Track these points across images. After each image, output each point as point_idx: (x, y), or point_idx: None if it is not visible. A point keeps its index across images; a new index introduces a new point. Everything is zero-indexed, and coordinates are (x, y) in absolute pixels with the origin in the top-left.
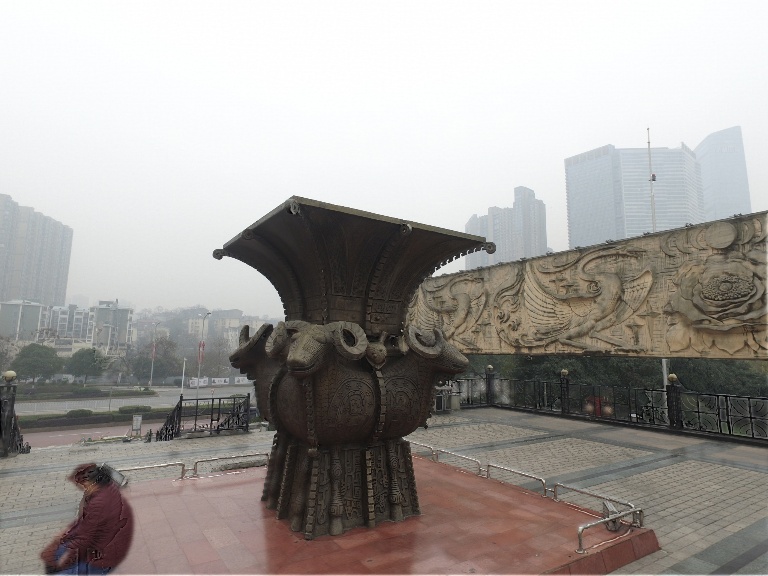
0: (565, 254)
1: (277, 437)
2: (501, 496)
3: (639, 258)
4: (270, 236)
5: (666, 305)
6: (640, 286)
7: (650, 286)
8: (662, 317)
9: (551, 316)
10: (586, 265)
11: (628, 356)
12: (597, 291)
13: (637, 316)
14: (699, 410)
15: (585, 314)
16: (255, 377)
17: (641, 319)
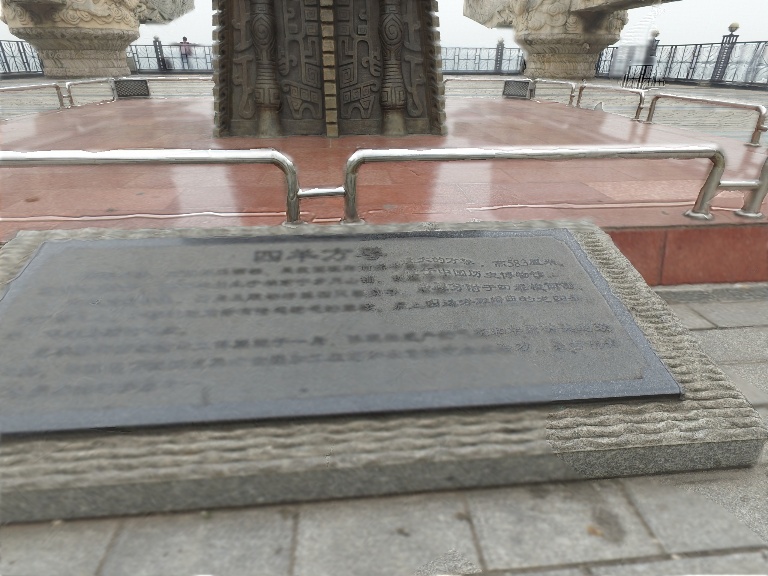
0: None
1: None
2: (104, 112)
3: None
4: None
5: None
6: None
7: None
8: None
9: None
10: None
11: None
12: None
13: None
14: None
15: None
16: None
17: None
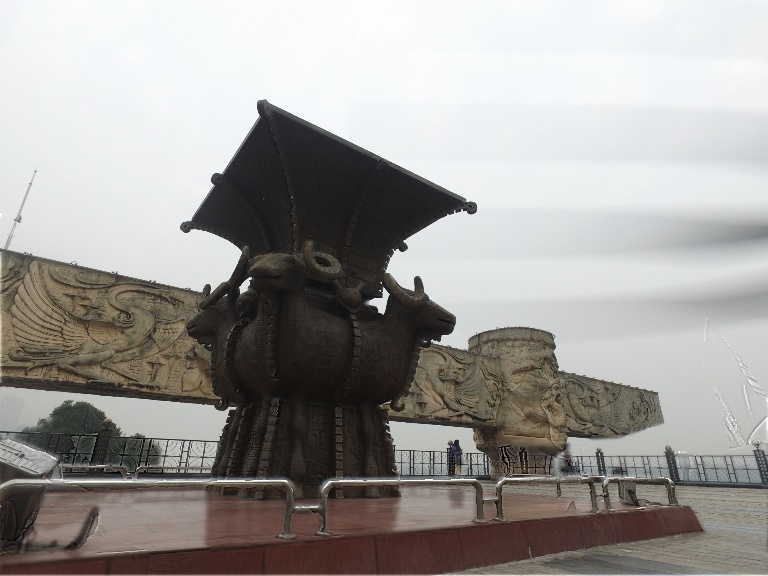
0: (97, 273)
1: (280, 403)
2: None
3: (176, 306)
4: (384, 181)
5: (189, 351)
6: (173, 330)
7: (182, 332)
8: (183, 360)
9: (54, 334)
10: (121, 293)
11: (140, 391)
12: (129, 323)
13: (161, 355)
14: (124, 453)
15: (107, 342)
16: (276, 311)
17: (164, 359)
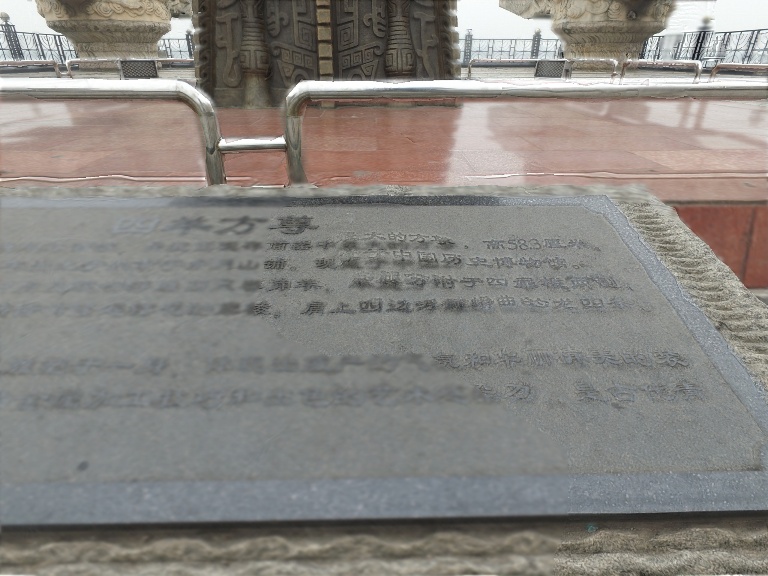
0: None
1: None
2: None
3: None
4: None
5: None
6: None
7: None
8: None
9: None
10: None
11: None
12: None
13: None
14: None
15: None
16: None
17: None
